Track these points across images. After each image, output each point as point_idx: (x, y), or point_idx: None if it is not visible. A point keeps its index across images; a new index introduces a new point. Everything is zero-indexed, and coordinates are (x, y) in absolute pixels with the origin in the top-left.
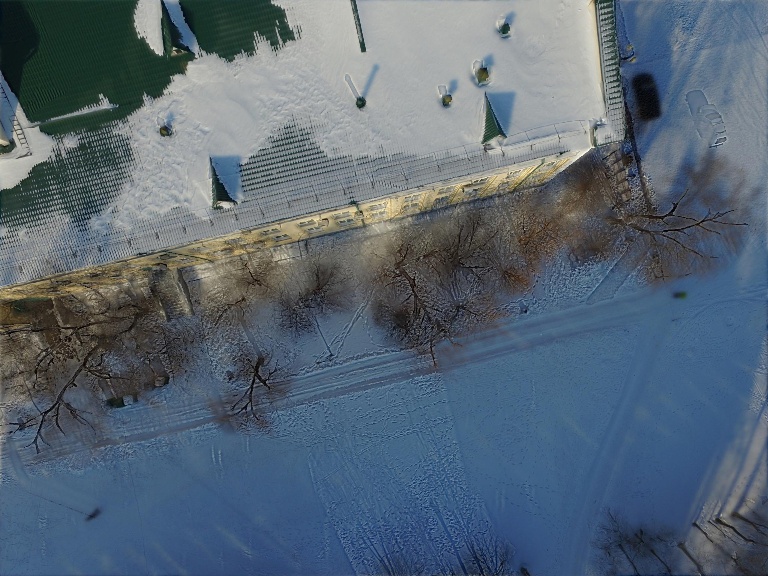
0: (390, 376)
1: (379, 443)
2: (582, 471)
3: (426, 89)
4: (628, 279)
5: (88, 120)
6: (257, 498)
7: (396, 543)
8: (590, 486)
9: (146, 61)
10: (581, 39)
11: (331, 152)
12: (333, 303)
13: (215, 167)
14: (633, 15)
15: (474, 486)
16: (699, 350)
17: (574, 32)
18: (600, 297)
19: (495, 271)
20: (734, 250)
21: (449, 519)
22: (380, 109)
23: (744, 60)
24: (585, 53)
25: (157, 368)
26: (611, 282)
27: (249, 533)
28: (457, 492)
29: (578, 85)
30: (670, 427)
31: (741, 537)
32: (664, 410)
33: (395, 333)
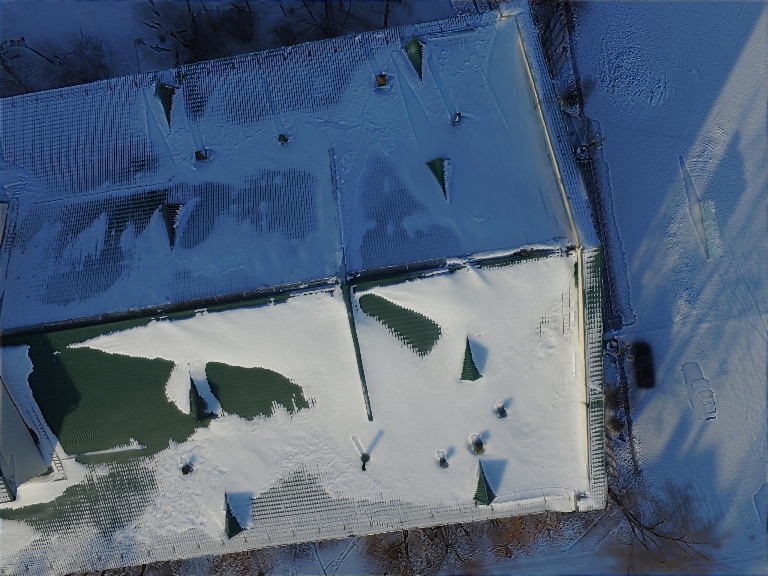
0: None
1: None
2: None
3: (426, 452)
4: (610, 535)
5: (119, 455)
6: None
7: None
8: None
9: (174, 417)
10: (572, 425)
11: (335, 494)
12: None
13: (229, 503)
14: (638, 283)
15: None
16: None
17: (566, 418)
18: (581, 549)
19: None
20: (713, 518)
21: None
22: (382, 464)
23: (742, 337)
24: (575, 436)
25: (166, 572)
26: (593, 535)
27: None
28: None
29: (566, 460)
30: None
31: None
32: None
33: (387, 564)
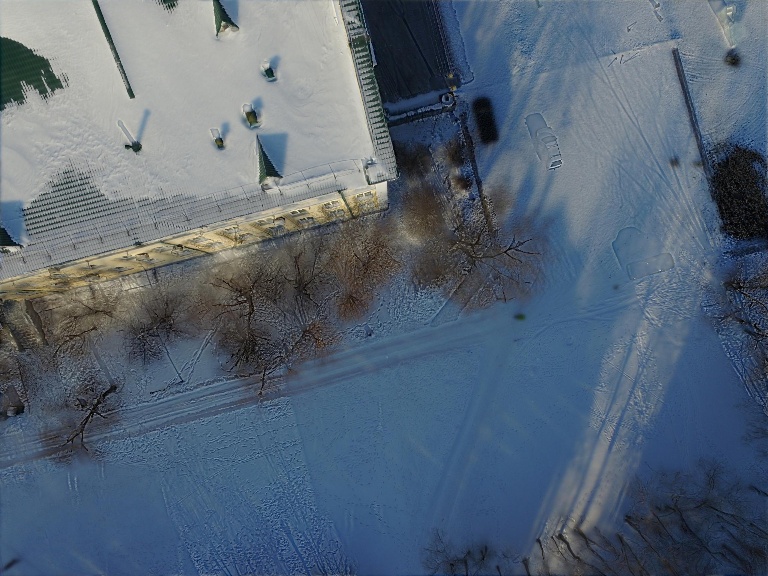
0: (240, 401)
1: (230, 467)
2: (429, 490)
3: (199, 132)
4: (471, 301)
5: None
6: (112, 523)
7: (249, 564)
8: (437, 505)
9: None
10: (346, 81)
11: (112, 195)
12: (182, 330)
13: None
14: (473, 40)
15: (323, 507)
16: (540, 369)
17: (339, 74)
18: (444, 319)
19: (341, 296)
20: (574, 270)
21: (300, 540)
22: (156, 153)
23: (582, 83)
24: (351, 95)
25: (12, 397)
26: (455, 304)
27: (105, 558)
28: (307, 513)
29: (348, 125)
30: (513, 446)
31: (571, 554)
32: (507, 429)
33: None
